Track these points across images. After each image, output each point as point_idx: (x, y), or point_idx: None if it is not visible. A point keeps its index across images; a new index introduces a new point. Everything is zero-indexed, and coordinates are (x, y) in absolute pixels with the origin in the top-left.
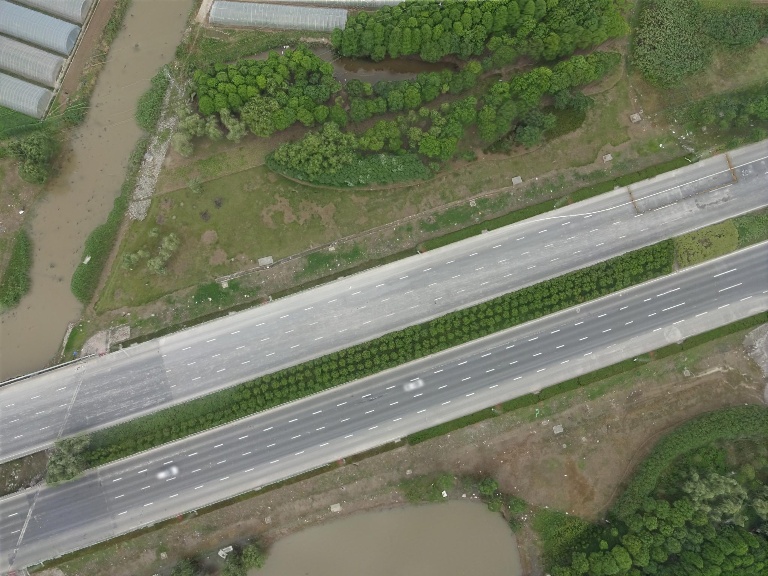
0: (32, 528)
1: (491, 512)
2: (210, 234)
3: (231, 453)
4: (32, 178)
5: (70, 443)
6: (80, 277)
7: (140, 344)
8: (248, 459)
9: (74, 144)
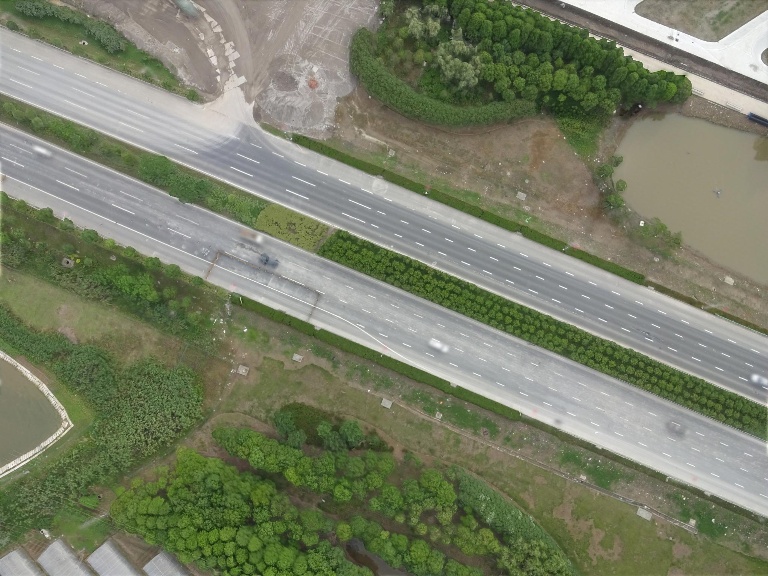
0: None
1: None
2: None
3: None
4: None
5: None
6: None
7: None
8: None
9: None
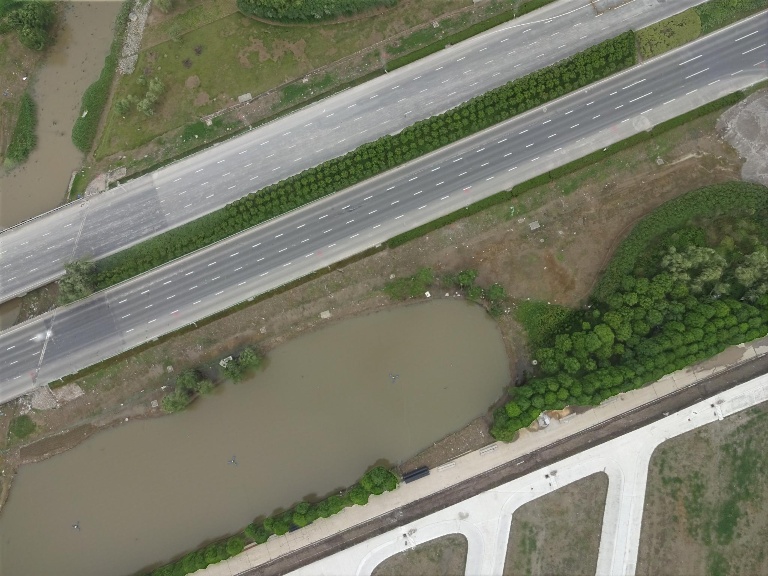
0: (51, 349)
1: (476, 312)
2: (193, 79)
3: (224, 269)
4: (30, 41)
5: (77, 264)
6: (79, 129)
7: (135, 180)
8: (240, 274)
9: (67, 14)
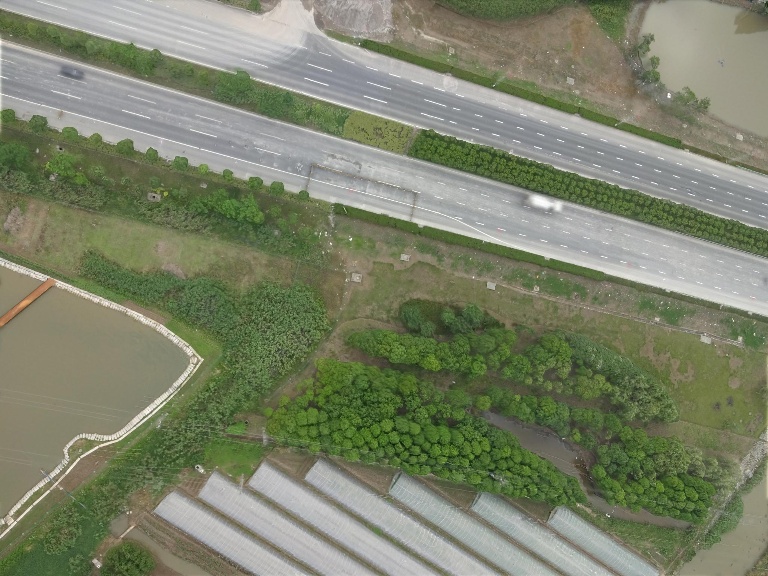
0: None
1: None
2: (733, 385)
3: None
4: None
5: None
6: None
7: None
8: None
9: None
